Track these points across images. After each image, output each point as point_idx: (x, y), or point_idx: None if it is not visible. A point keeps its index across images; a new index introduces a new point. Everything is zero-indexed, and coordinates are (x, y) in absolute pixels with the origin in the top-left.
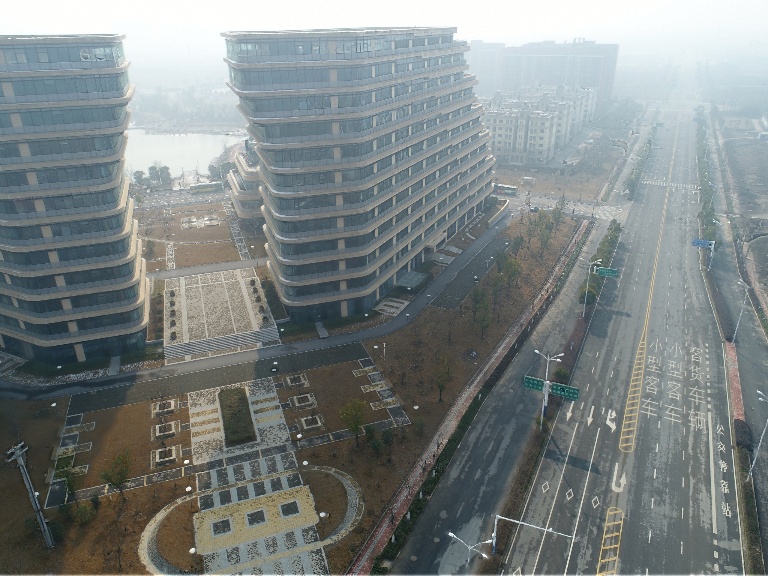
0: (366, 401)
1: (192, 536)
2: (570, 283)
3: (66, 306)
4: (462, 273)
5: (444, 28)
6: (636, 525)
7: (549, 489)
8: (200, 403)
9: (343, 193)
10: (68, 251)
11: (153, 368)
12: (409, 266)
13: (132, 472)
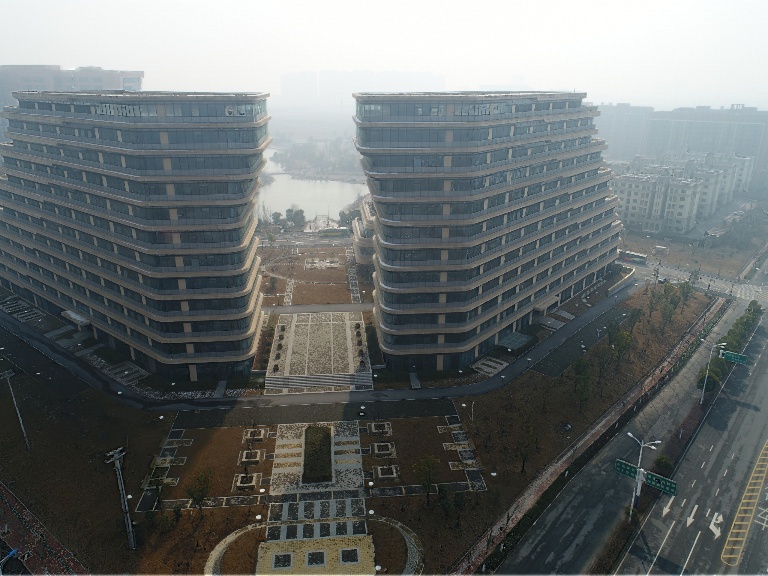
0: (445, 459)
1: (254, 564)
2: (692, 365)
3: (187, 329)
4: (570, 340)
5: (572, 93)
6: None
7: None
8: (287, 436)
9: (449, 248)
10: (195, 280)
11: (253, 396)
12: (514, 327)
13: (214, 492)
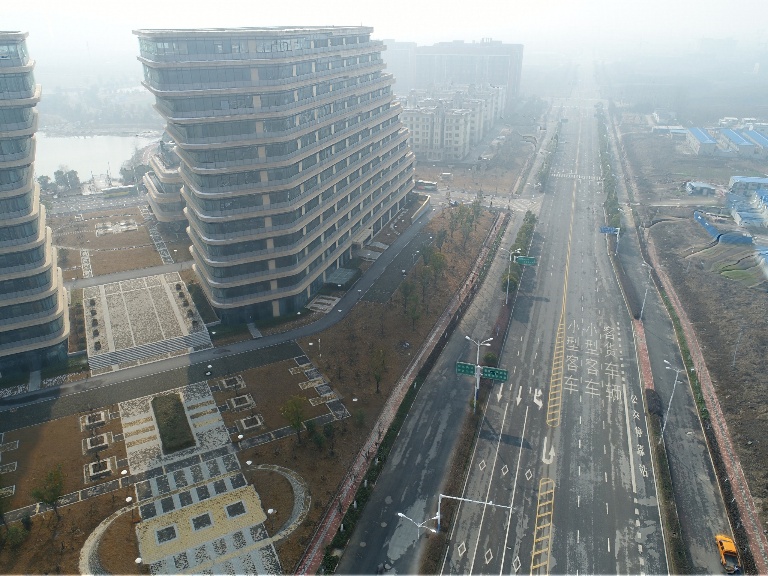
0: None
1: (136, 546)
2: (492, 273)
3: None
4: (390, 268)
5: (361, 28)
6: (566, 492)
7: (486, 467)
8: (132, 412)
9: (270, 192)
10: None
11: (78, 380)
12: (338, 263)
13: (64, 488)
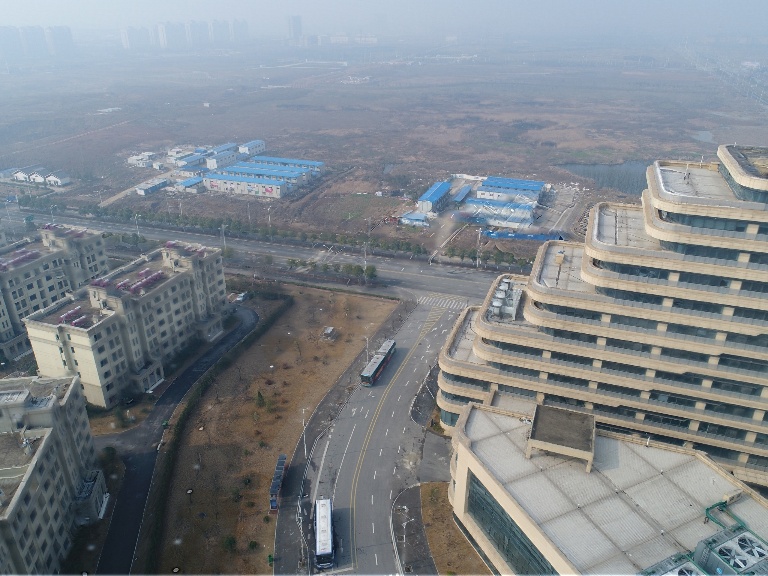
0: None
1: None
2: None
3: None
4: None
5: None
6: None
7: None
8: None
9: None
10: None
11: None
12: None
13: None
